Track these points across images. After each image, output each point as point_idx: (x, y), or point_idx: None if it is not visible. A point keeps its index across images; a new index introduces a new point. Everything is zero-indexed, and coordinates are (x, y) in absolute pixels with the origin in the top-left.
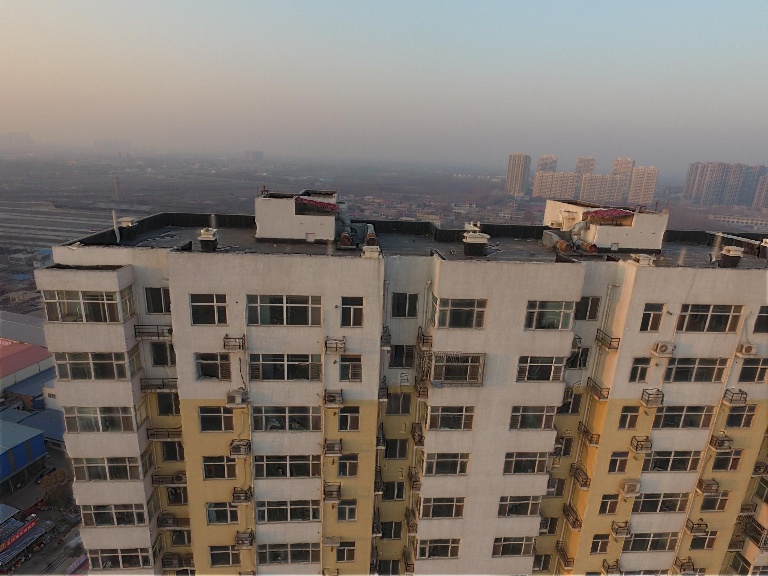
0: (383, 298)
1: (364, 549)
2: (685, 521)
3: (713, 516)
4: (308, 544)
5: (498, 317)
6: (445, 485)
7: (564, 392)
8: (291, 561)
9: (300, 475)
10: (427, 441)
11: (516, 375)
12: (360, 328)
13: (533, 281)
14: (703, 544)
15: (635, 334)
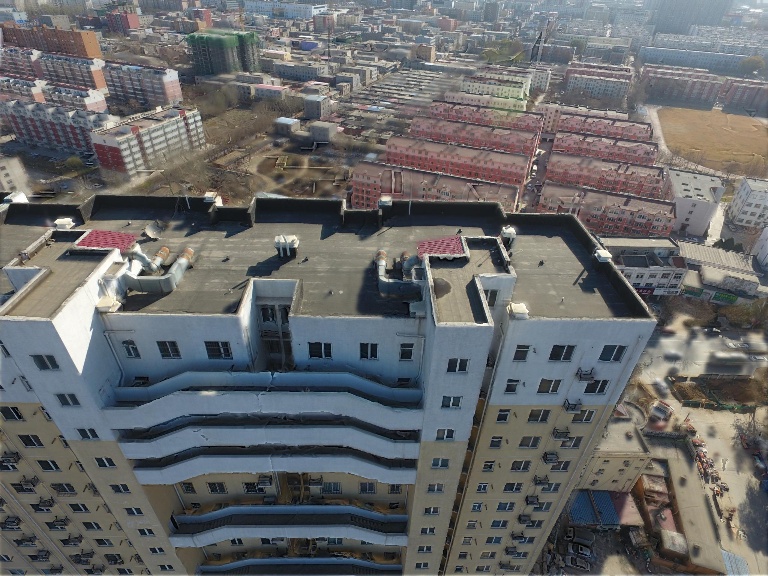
0: None
1: None
2: None
3: None
4: None
5: None
6: None
7: None
8: None
9: None
10: None
11: None
12: None
13: None
14: None
15: None
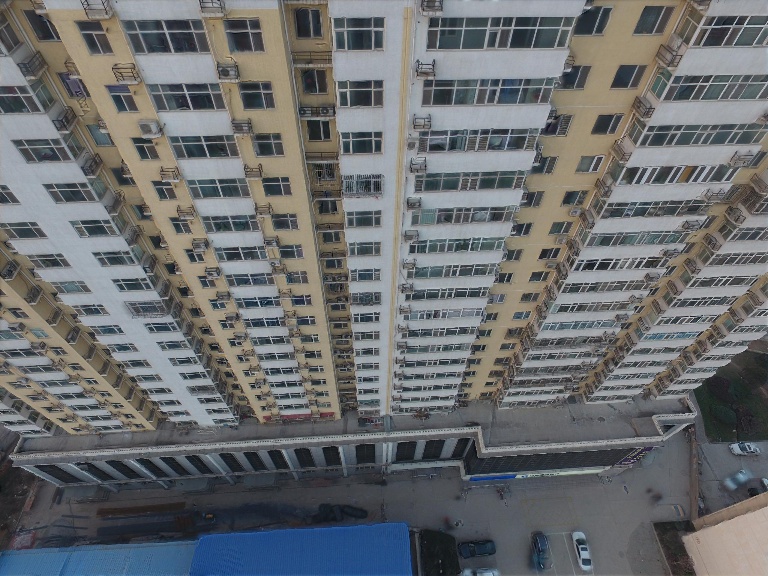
0: None
1: None
2: (243, 167)
3: (273, 161)
4: None
5: None
6: None
7: None
8: None
9: None
10: None
11: None
12: None
13: None
14: (281, 191)
15: None
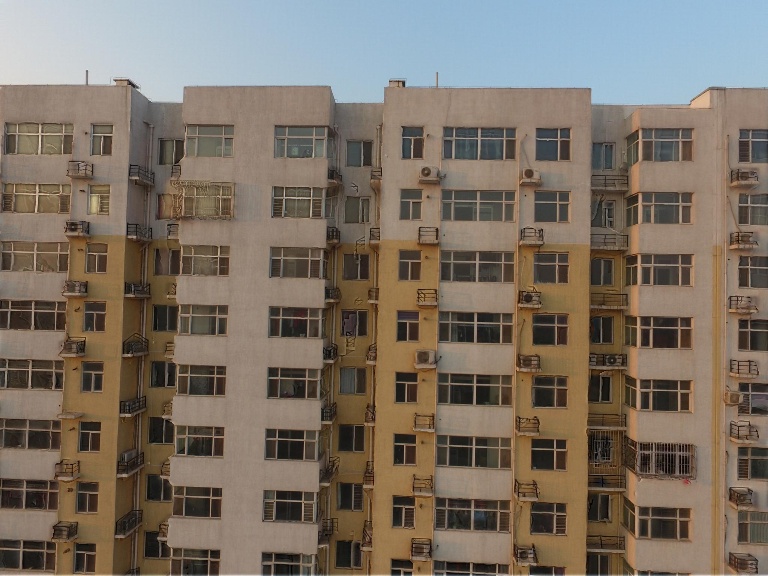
0: (130, 124)
1: (110, 434)
2: (513, 419)
3: (552, 414)
4: (49, 423)
5: (245, 143)
6: (201, 348)
7: (328, 232)
8: (29, 447)
9: (46, 329)
10: (179, 288)
11: (271, 209)
12: (109, 156)
13: (278, 105)
14: (551, 463)
15: (396, 161)
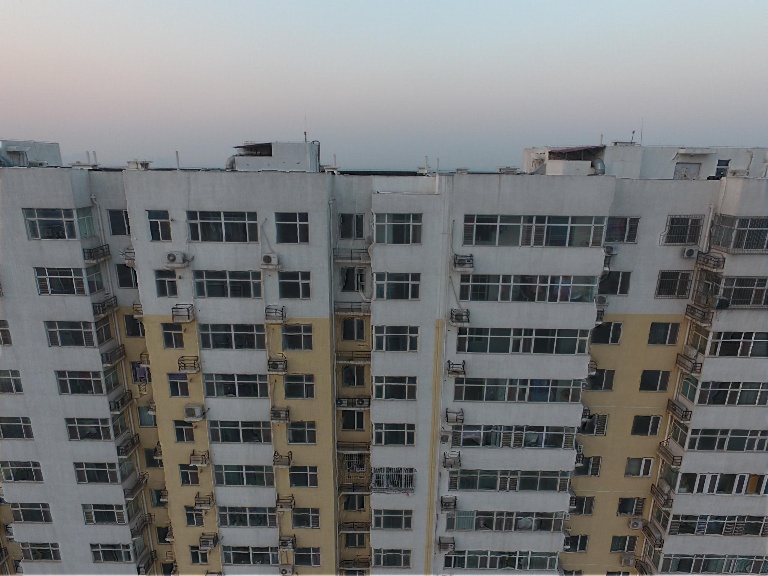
0: None
1: None
2: (273, 453)
3: (304, 449)
4: None
5: None
6: (3, 403)
7: (95, 307)
8: None
9: None
10: None
11: (36, 287)
12: None
13: (20, 187)
14: (307, 481)
15: (146, 244)
